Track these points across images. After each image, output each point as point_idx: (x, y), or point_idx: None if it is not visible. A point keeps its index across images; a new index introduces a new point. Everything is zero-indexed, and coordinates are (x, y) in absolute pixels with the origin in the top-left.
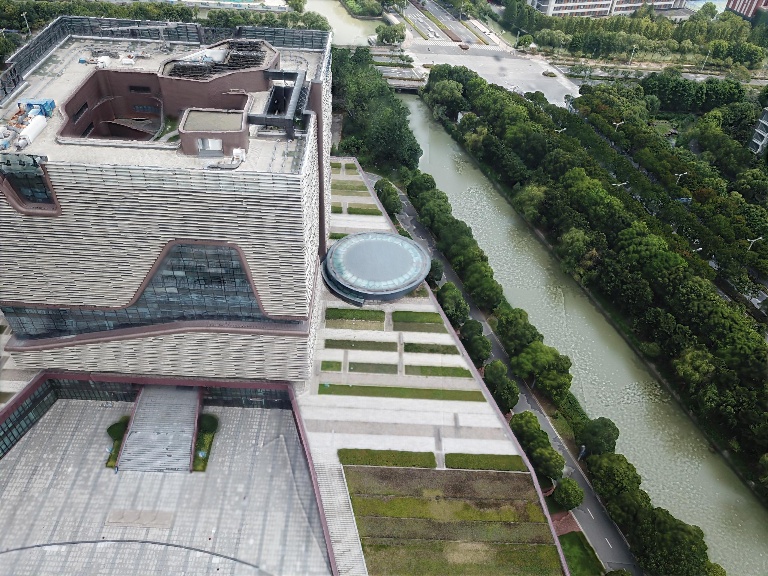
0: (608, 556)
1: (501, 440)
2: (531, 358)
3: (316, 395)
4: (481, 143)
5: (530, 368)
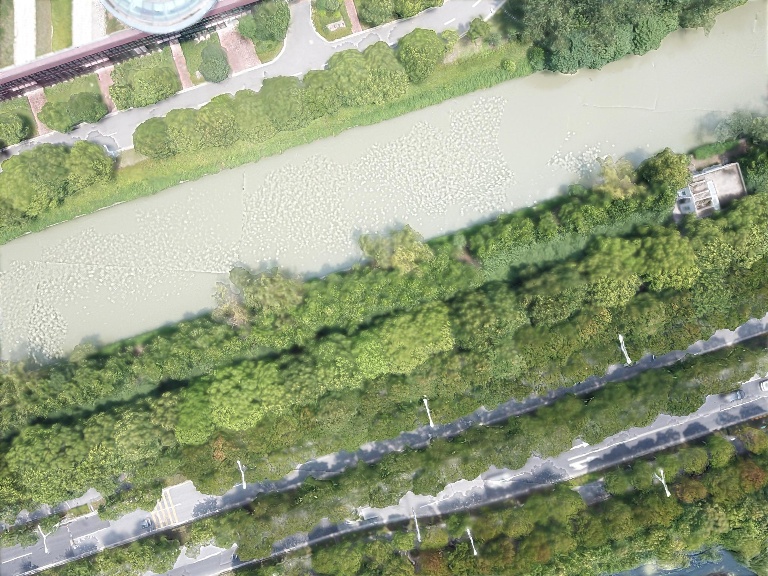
0: None
1: None
2: (8, 168)
3: None
4: (595, 188)
5: (2, 167)
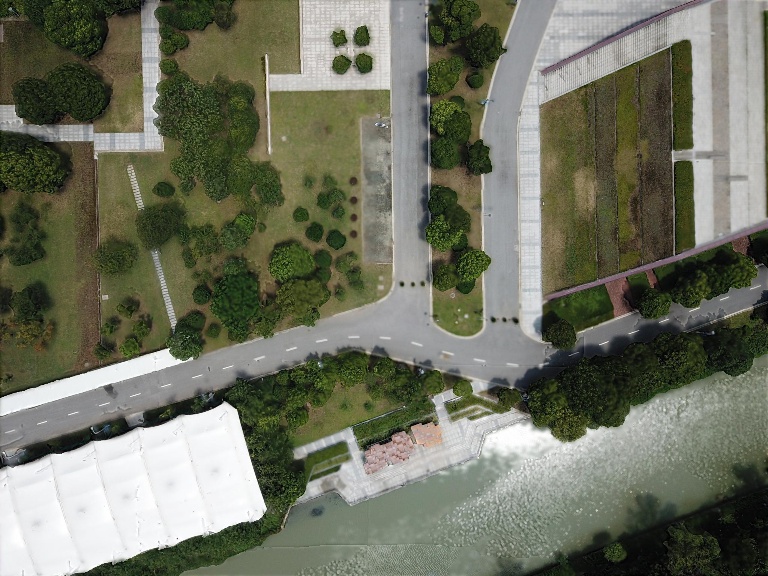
0: (590, 339)
1: (714, 228)
2: None
3: (763, 8)
4: None
5: None
